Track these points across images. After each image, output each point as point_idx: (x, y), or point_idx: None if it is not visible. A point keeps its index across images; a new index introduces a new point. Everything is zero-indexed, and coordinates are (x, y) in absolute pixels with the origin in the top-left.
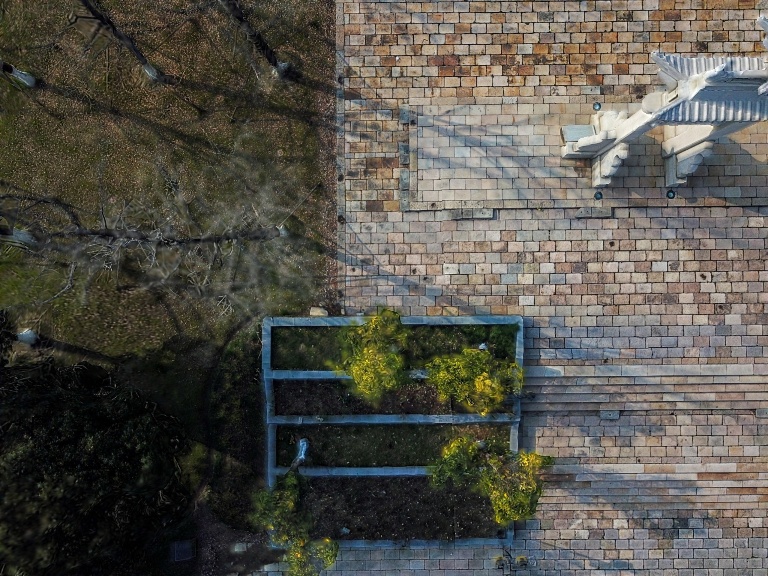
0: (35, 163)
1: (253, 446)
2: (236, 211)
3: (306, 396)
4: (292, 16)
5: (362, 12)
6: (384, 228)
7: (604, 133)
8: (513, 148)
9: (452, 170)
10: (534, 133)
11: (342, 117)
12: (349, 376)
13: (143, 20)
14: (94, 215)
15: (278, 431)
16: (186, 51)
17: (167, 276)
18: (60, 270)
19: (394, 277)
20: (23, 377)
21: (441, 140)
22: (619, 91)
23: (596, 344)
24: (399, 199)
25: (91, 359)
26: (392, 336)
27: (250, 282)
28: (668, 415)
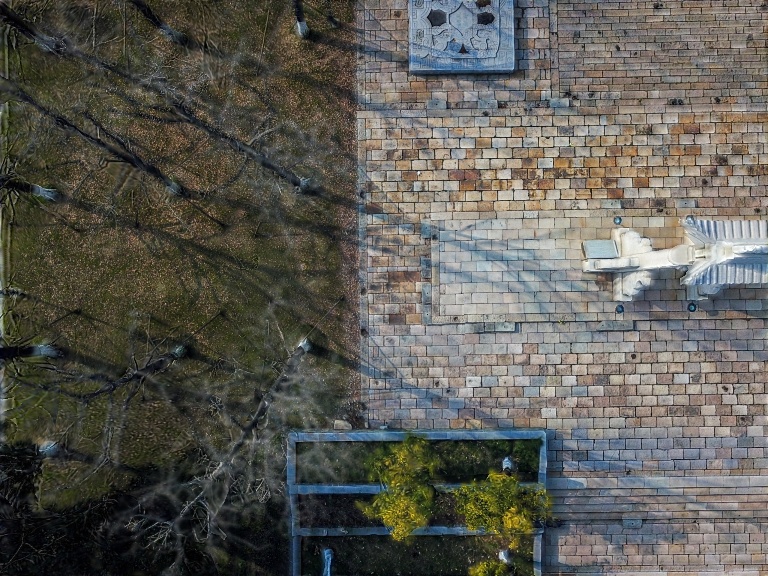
0: (61, 278)
1: (278, 555)
2: (260, 325)
3: (330, 509)
4: (314, 132)
5: (384, 127)
6: (407, 341)
7: (627, 260)
8: (534, 262)
9: (474, 284)
10: (555, 247)
11: (364, 231)
12: (373, 491)
13: (167, 137)
14: (120, 329)
15: (303, 542)
16: (210, 167)
17: (216, 513)
18: (98, 440)
19: (417, 390)
20: (60, 536)
21: (463, 255)
22: (639, 204)
23: (618, 456)
24: (422, 313)
25: (117, 471)
26: (418, 466)
27: (274, 395)
28: (690, 523)
